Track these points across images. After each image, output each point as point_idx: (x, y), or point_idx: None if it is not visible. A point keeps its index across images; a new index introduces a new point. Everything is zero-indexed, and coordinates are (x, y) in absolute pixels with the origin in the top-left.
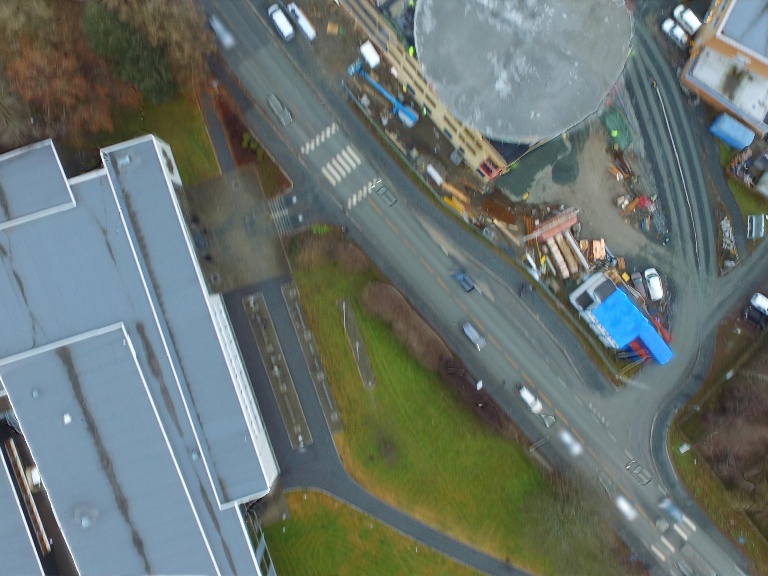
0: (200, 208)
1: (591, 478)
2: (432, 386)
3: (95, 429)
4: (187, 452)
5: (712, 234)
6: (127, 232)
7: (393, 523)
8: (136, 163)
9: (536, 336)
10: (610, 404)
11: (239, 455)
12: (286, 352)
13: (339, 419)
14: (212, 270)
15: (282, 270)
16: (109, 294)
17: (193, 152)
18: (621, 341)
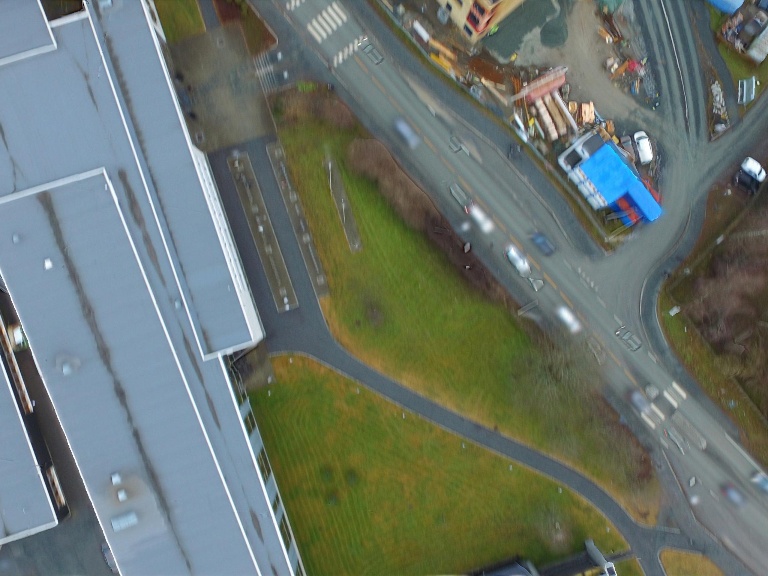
0: (184, 65)
1: (580, 343)
2: (419, 249)
3: (76, 276)
4: (170, 302)
5: (702, 99)
6: (109, 76)
7: (380, 389)
8: (118, 6)
9: (524, 198)
10: (599, 269)
11: (222, 305)
12: (271, 213)
13: (325, 283)
14: (196, 129)
15: (267, 129)
16: (91, 140)
17: (177, 8)
18: (610, 196)
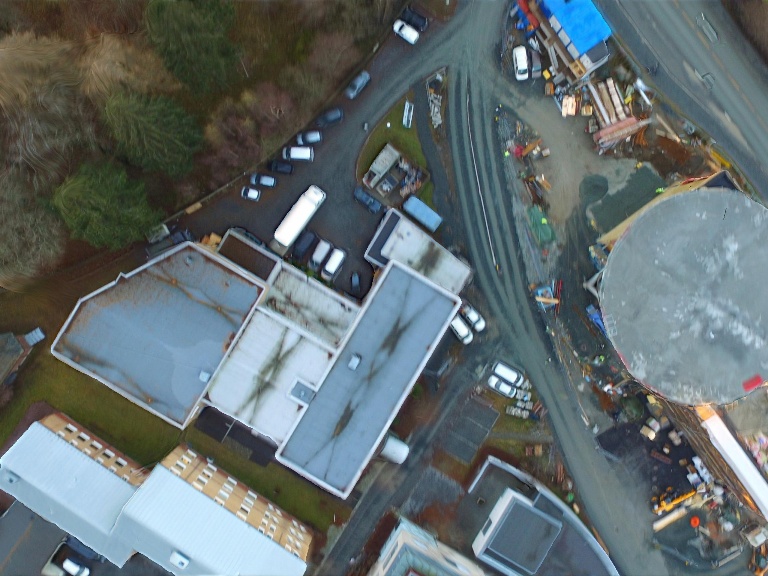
0: None
1: None
2: None
3: None
4: None
5: (451, 112)
6: None
7: None
8: None
9: (646, 22)
10: None
11: None
12: None
13: None
14: None
15: None
16: None
17: None
18: None
